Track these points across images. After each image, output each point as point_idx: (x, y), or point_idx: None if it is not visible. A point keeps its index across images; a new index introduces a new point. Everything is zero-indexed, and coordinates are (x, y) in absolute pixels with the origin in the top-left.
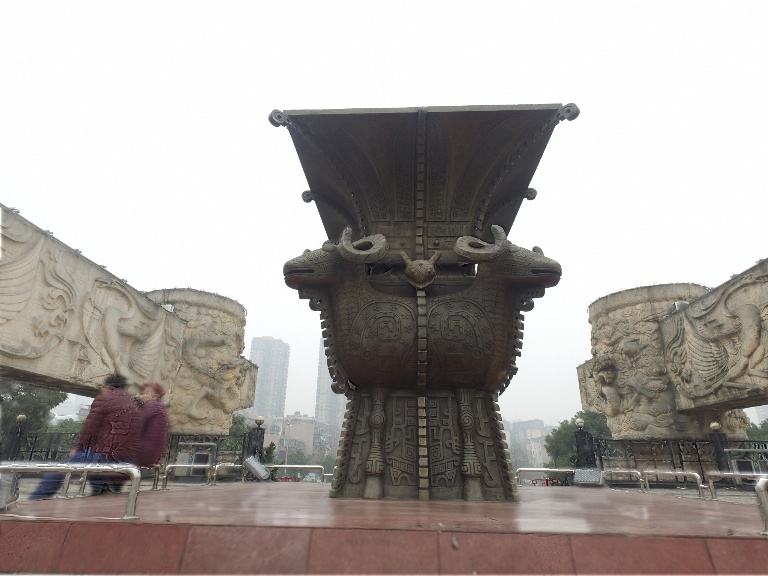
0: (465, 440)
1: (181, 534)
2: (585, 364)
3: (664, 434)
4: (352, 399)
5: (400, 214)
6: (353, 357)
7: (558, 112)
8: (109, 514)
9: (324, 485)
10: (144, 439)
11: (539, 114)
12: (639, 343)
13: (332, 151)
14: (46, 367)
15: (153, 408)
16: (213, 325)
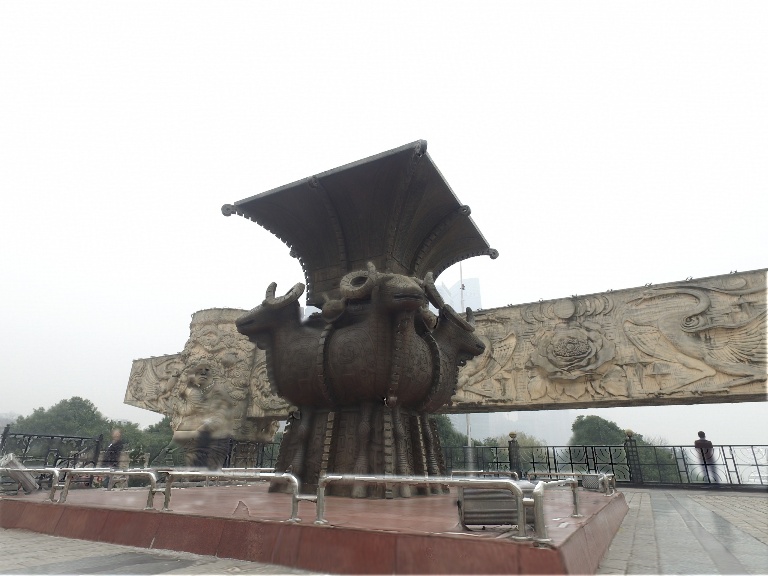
0: (431, 451)
1: None
2: (149, 359)
3: None
4: None
5: (406, 260)
6: (407, 378)
7: (489, 250)
8: None
9: None
10: None
11: (483, 245)
12: (237, 357)
13: (409, 189)
14: None
15: None
16: None
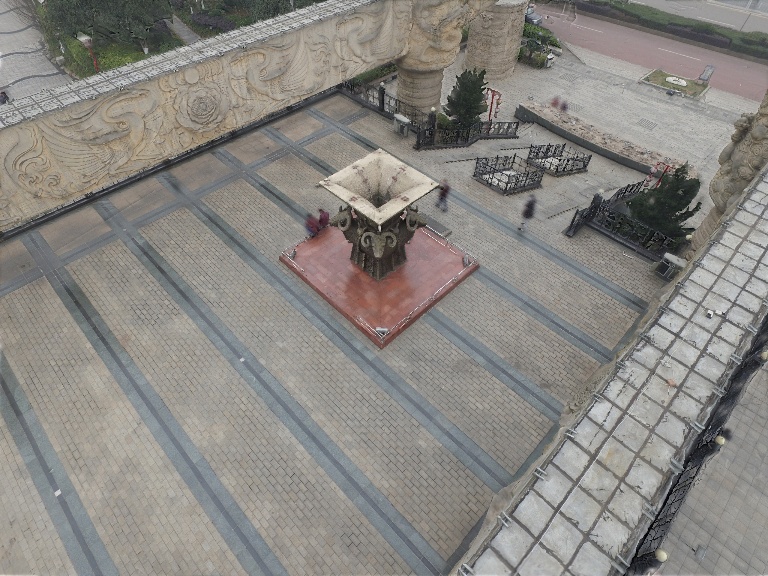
0: None
1: (306, 280)
2: None
3: (719, 205)
4: (353, 244)
5: None
6: None
7: None
8: (303, 266)
9: None
10: (323, 223)
11: None
12: (767, 132)
13: None
14: (327, 85)
15: (323, 216)
16: None
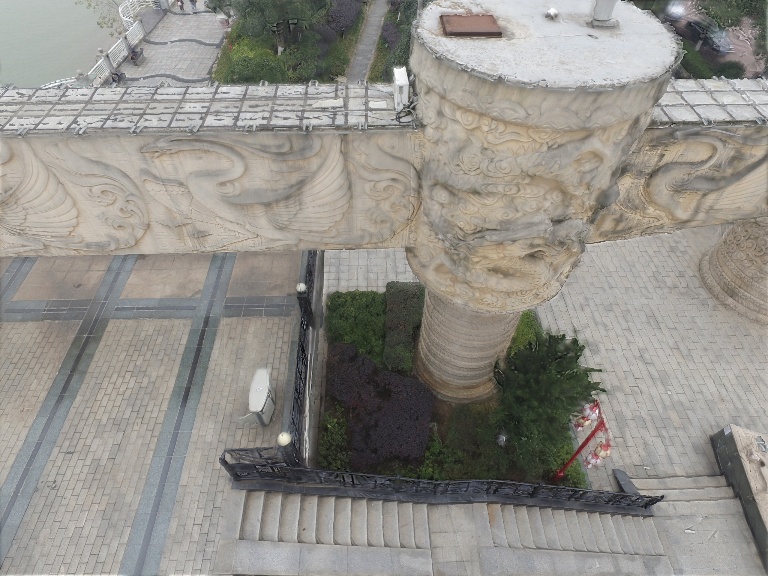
0: None
1: None
2: None
3: None
4: None
5: None
6: None
7: None
8: None
9: None
10: None
11: None
12: None
13: None
14: (153, 248)
15: None
16: (464, 148)
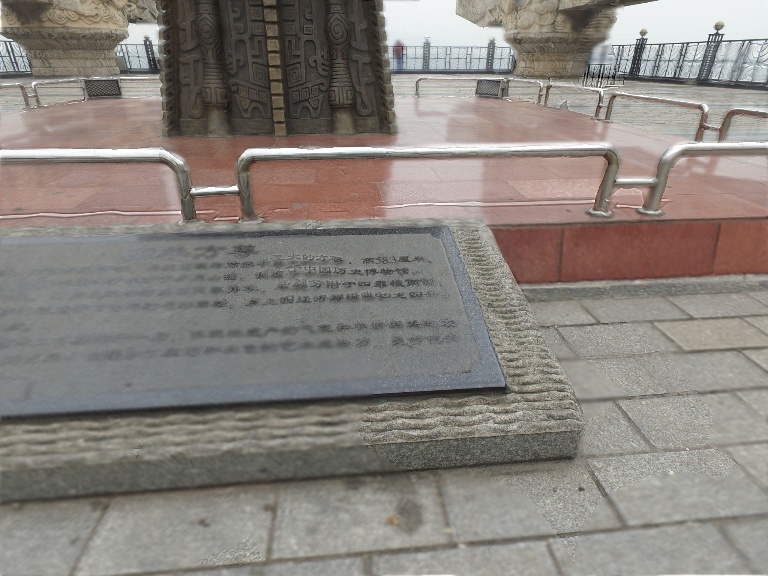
0: None
1: None
2: None
3: None
4: None
5: None
6: None
7: None
8: None
9: (517, 163)
10: None
11: None
12: None
13: None
14: None
15: None
16: None
